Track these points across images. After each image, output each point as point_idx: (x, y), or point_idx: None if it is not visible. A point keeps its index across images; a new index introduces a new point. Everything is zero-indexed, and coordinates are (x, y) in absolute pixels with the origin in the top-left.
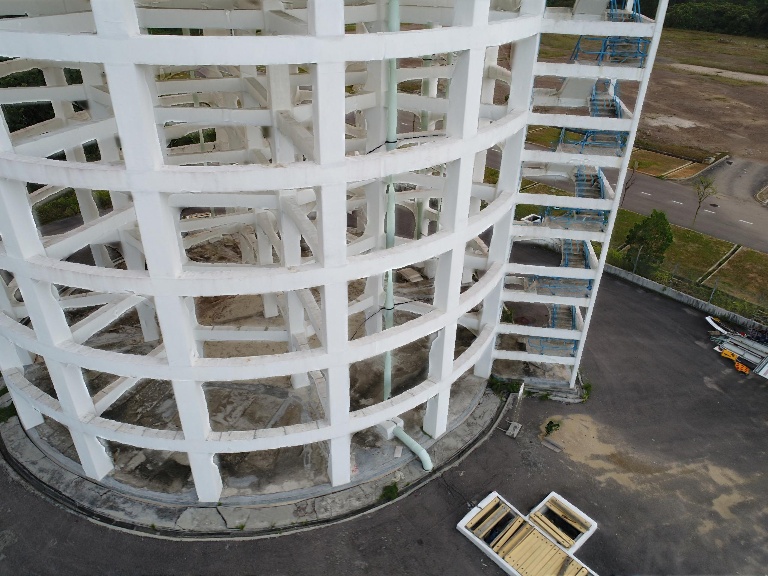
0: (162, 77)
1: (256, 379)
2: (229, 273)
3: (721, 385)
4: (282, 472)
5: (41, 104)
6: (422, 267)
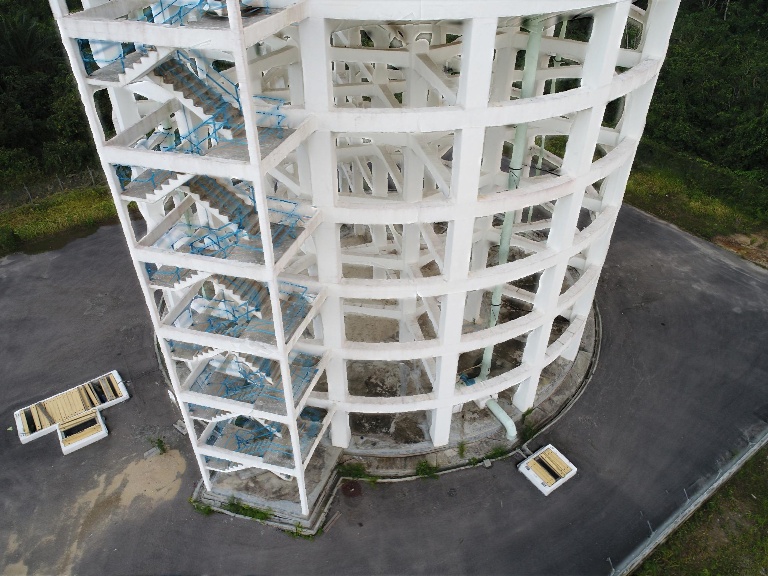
0: (447, 69)
1: None
2: (150, 141)
3: None
4: (199, 292)
5: (751, 98)
6: (474, 400)
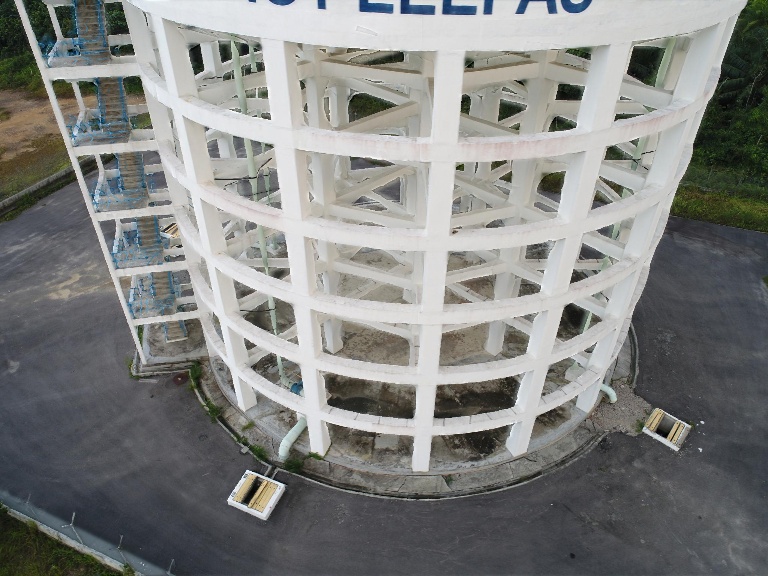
0: None
1: (373, 254)
2: None
3: (5, 367)
4: None
5: None
6: None
